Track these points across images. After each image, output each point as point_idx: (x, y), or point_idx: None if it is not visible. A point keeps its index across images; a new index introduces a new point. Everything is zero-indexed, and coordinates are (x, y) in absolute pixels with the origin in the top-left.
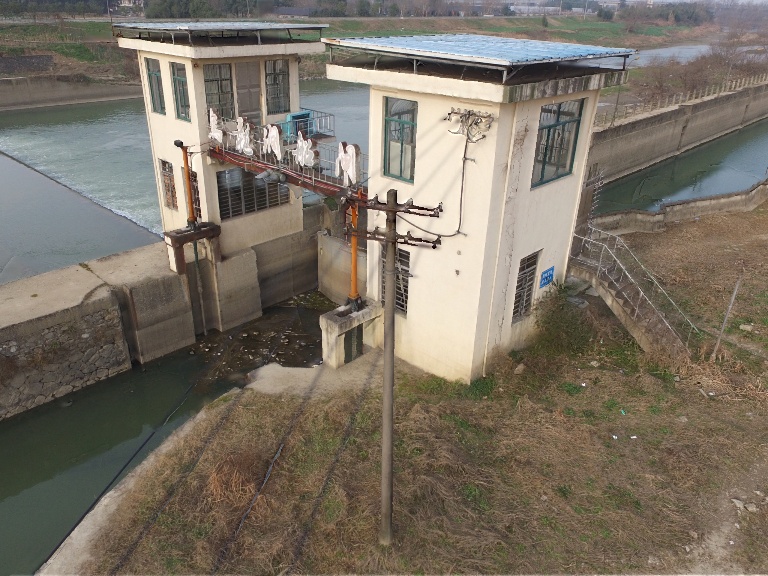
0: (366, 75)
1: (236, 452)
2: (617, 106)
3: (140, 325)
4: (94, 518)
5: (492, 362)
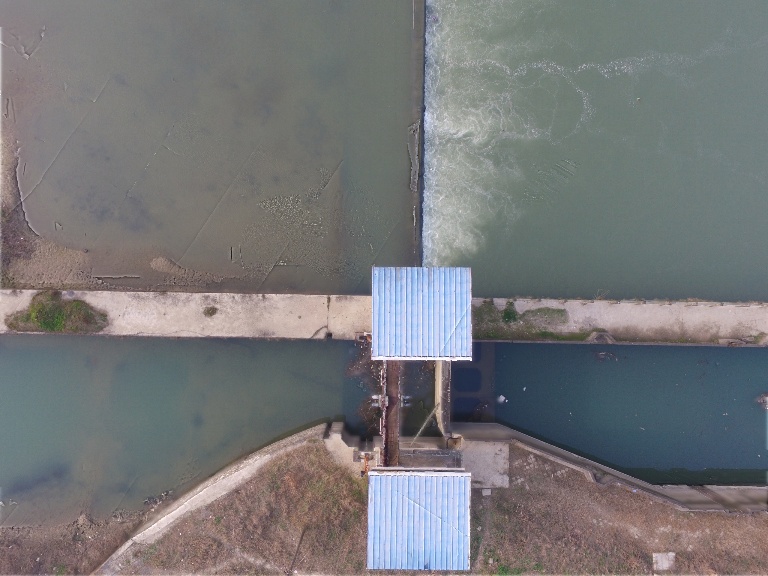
0: None
1: (301, 468)
2: None
3: None
4: (261, 461)
5: None
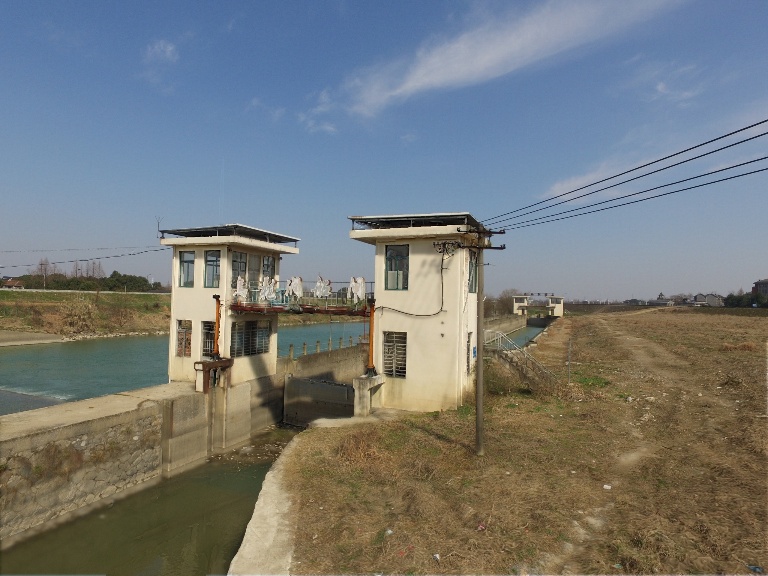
0: (379, 232)
1: None
2: None
3: (173, 434)
4: (271, 481)
5: (464, 397)
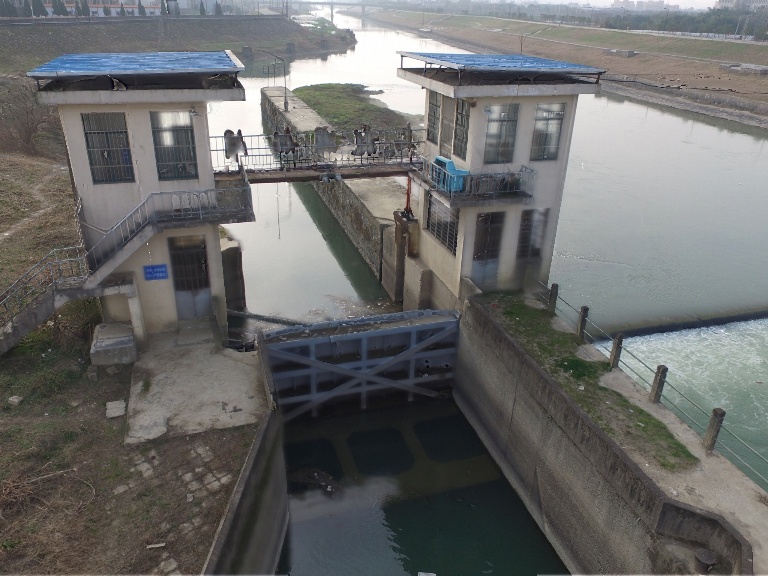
0: None
1: None
2: None
3: None
4: None
5: None
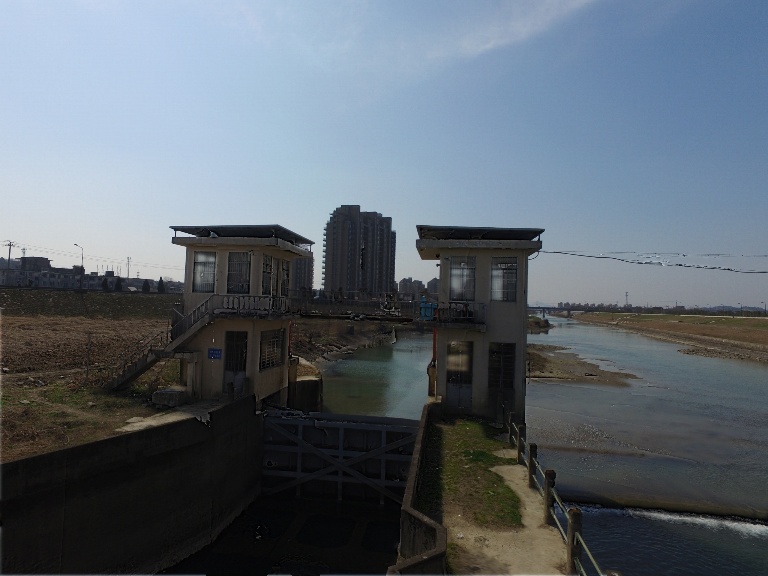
0: None
1: None
2: None
3: None
4: None
5: None
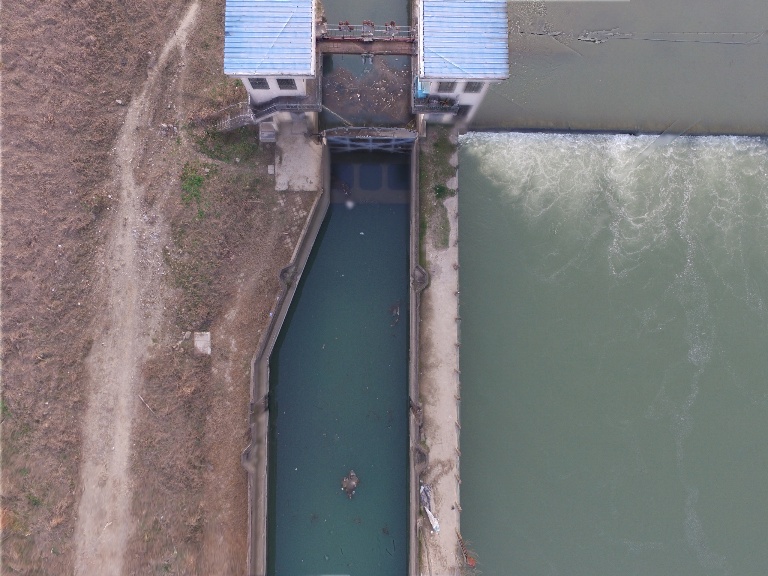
0: None
1: None
2: (422, 532)
3: None
4: None
5: None
